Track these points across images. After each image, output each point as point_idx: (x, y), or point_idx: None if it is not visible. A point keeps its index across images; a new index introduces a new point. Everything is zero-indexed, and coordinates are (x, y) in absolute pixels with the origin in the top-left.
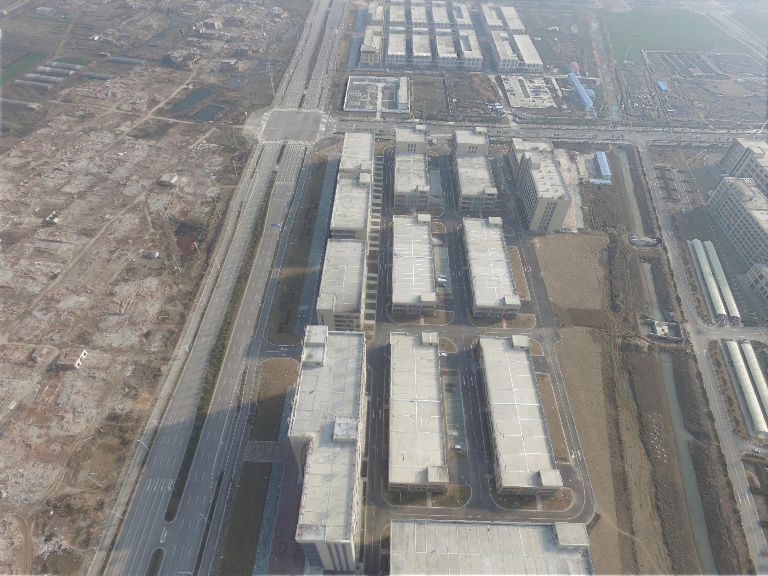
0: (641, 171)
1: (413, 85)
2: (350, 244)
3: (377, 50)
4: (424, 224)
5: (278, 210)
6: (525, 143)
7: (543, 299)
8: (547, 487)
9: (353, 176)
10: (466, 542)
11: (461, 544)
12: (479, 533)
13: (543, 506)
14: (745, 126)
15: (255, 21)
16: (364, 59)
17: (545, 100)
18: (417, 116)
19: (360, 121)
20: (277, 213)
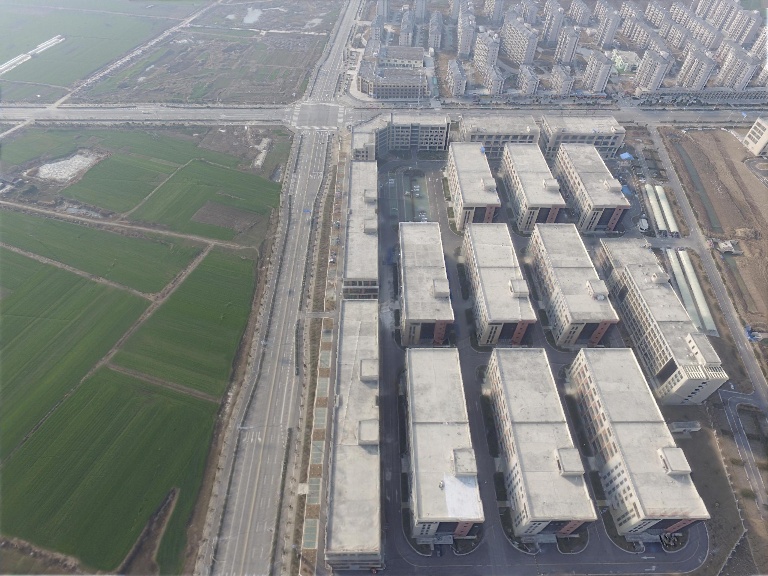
0: None
1: None
2: None
3: None
4: None
5: None
6: None
7: None
8: None
9: None
10: None
11: None
12: None
13: None
14: None
15: None
16: None
17: None
18: None
19: None
20: None
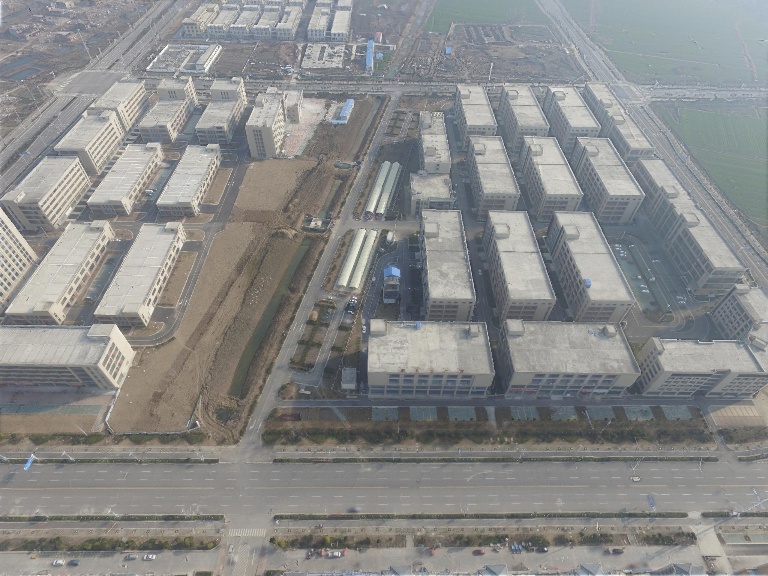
0: (380, 114)
1: (223, 52)
2: (63, 160)
3: (197, 22)
4: (152, 150)
5: (41, 144)
6: (279, 91)
7: (229, 204)
8: (128, 314)
9: (100, 113)
10: (22, 338)
11: (17, 339)
12: (36, 333)
13: (133, 333)
14: (499, 81)
15: (109, 2)
16: (187, 30)
17: (334, 62)
18: (210, 75)
19: (156, 79)
20: (39, 146)
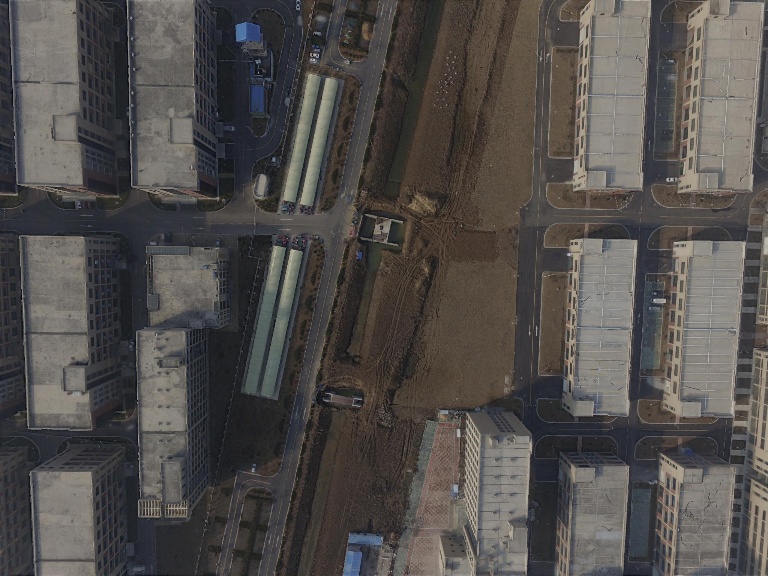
0: (282, 575)
1: None
2: None
3: None
4: (688, 400)
5: None
6: None
7: (526, 274)
8: None
9: None
10: None
11: None
12: None
13: None
14: None
15: None
16: None
17: None
18: None
19: None
20: None
